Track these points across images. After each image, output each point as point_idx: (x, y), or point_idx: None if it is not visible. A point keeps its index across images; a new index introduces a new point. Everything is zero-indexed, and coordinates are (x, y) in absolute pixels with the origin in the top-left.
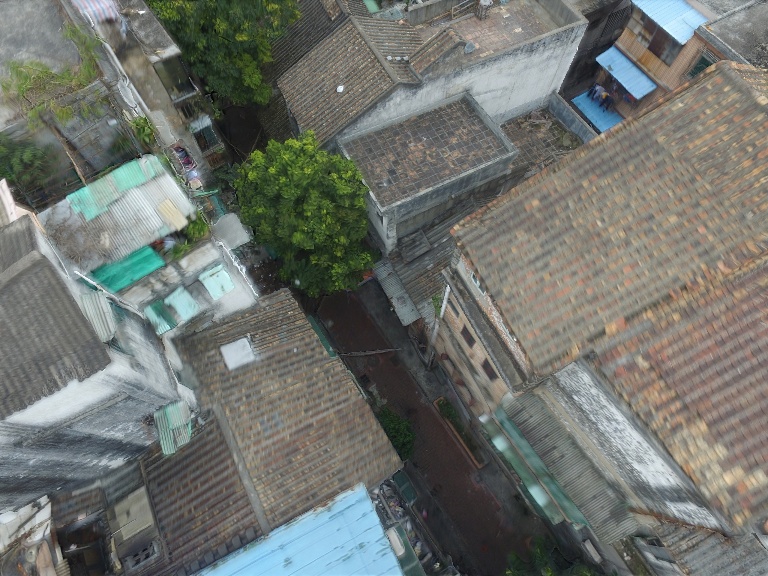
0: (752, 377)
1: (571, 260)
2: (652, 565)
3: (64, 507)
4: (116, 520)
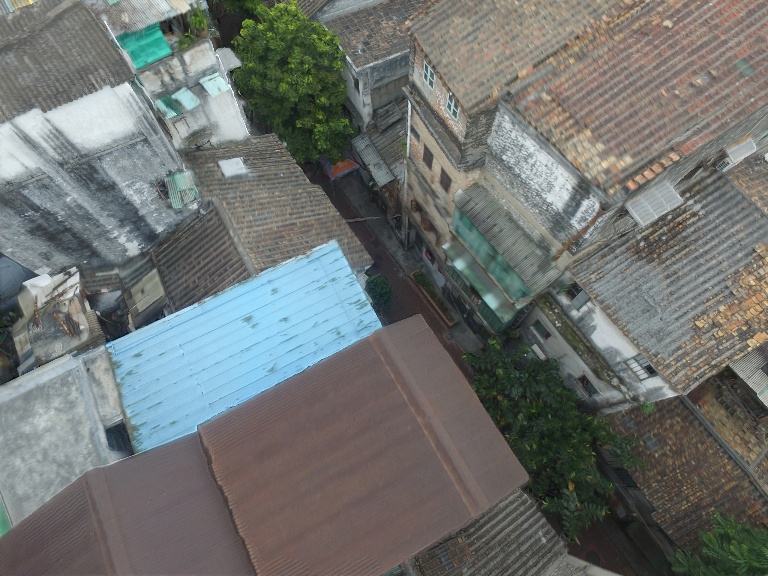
0: (624, 93)
1: (494, 31)
2: (577, 324)
3: (89, 281)
4: (132, 299)
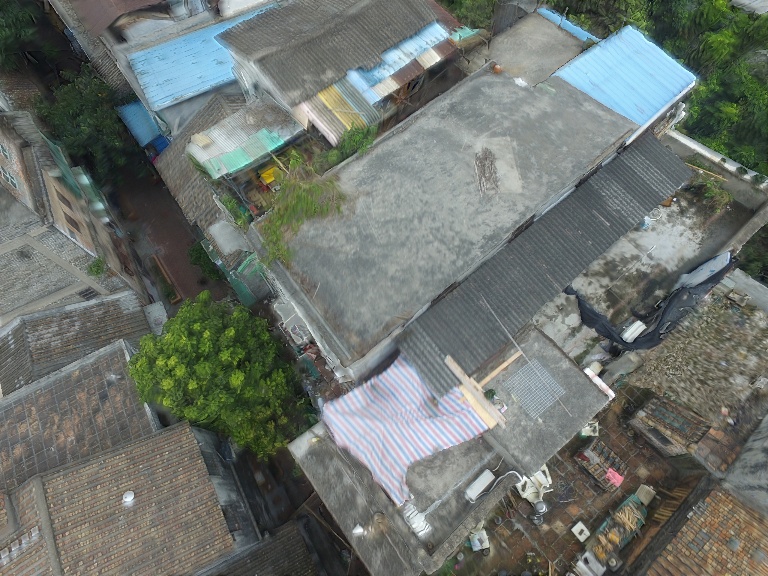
0: None
1: None
2: None
3: None
4: None
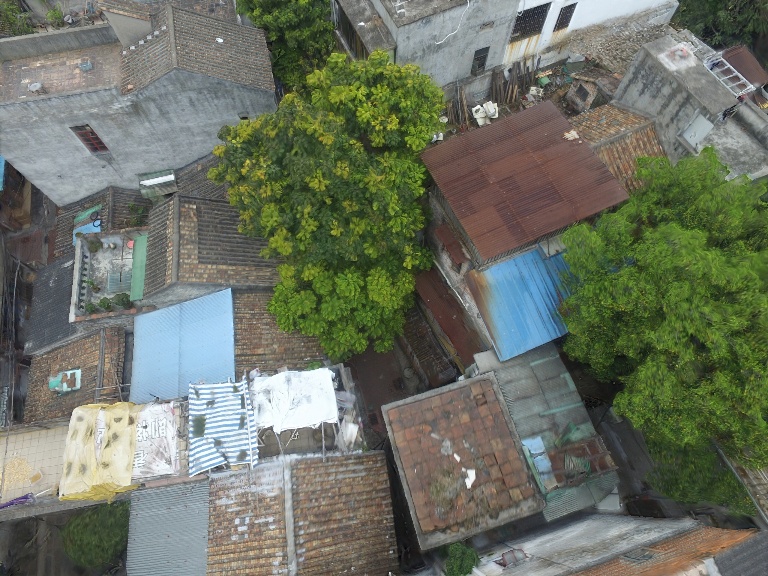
0: None
1: None
2: None
3: None
4: None
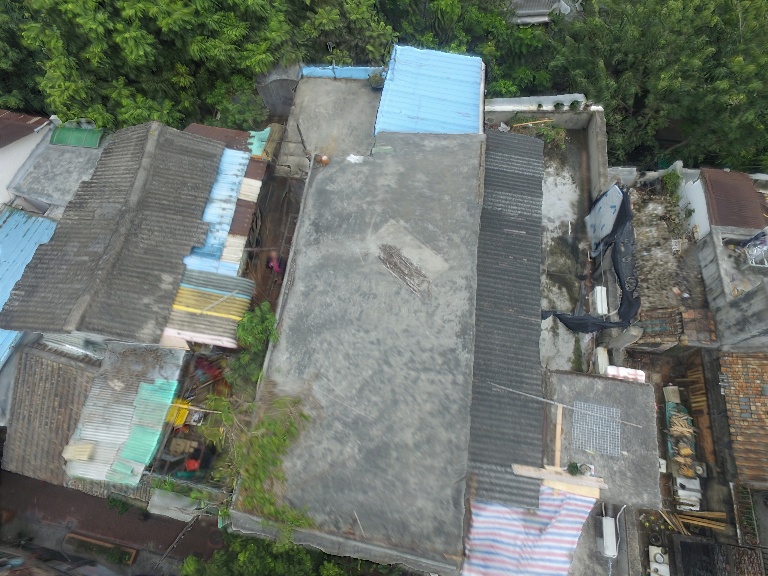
0: None
1: None
2: None
3: None
4: None
